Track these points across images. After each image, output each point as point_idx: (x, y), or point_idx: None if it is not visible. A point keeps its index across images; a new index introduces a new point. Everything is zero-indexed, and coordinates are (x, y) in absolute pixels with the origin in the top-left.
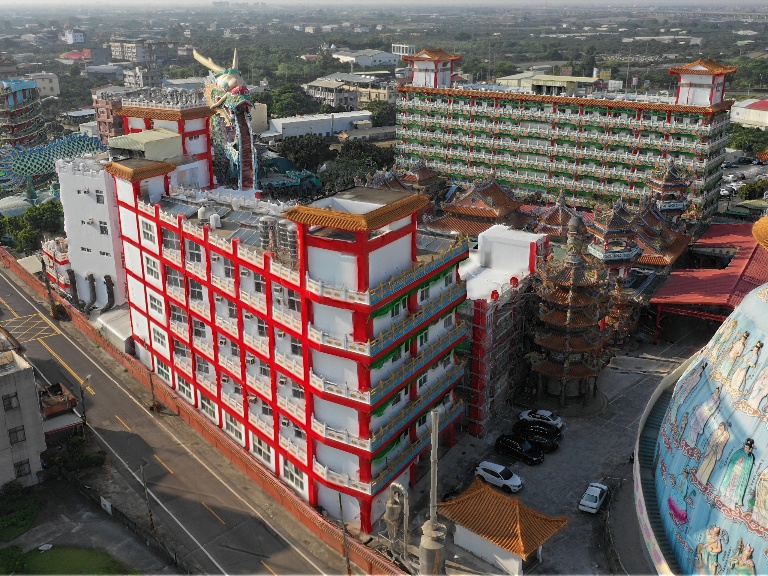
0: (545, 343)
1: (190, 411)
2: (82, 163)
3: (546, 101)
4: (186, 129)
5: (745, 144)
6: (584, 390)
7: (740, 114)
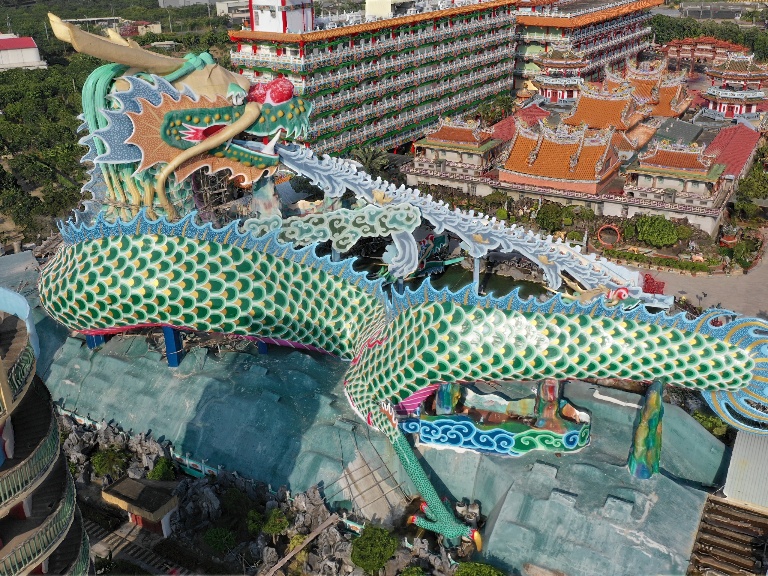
0: None
1: None
2: None
3: (430, 18)
4: None
5: None
6: None
7: None
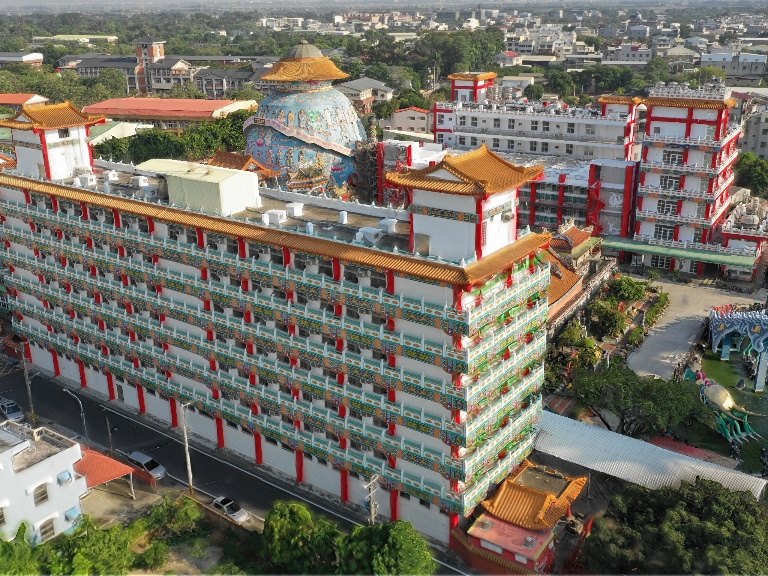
0: None
1: None
2: None
3: None
4: None
5: None
6: None
7: None
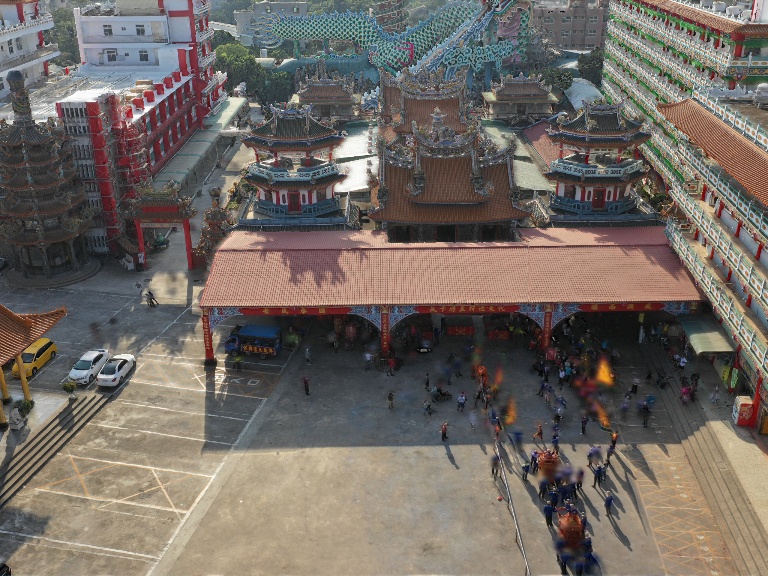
0: (7, 197)
1: None
2: None
3: None
4: None
5: None
6: (37, 263)
7: None
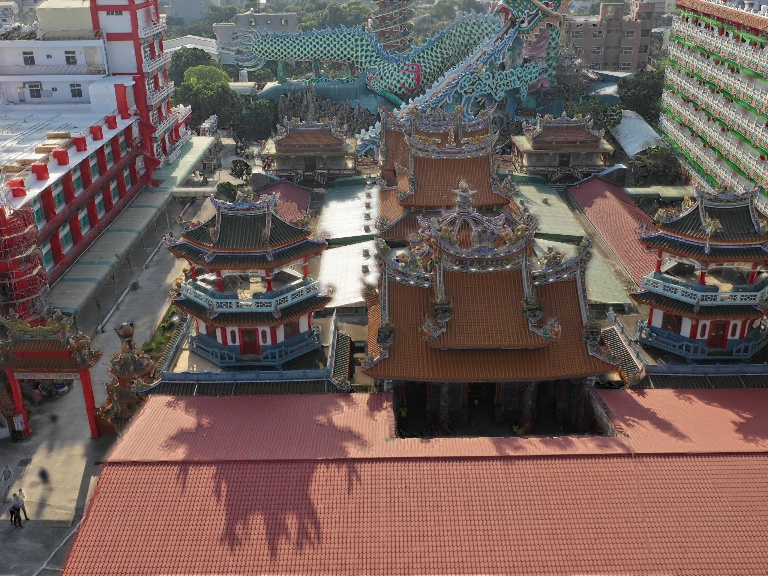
0: None
1: None
2: None
3: None
4: (100, 1)
5: None
6: None
7: None
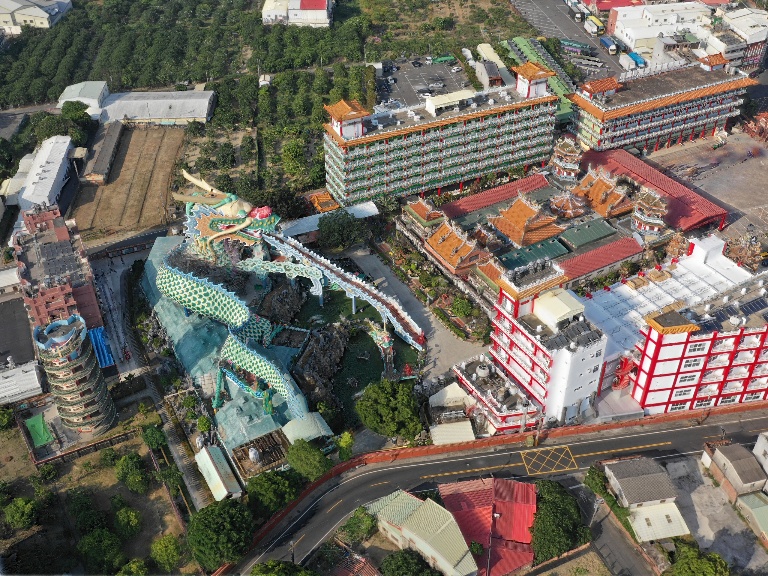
0: None
1: (727, 408)
2: (574, 343)
3: None
4: None
5: (380, 57)
6: None
7: (299, 15)
